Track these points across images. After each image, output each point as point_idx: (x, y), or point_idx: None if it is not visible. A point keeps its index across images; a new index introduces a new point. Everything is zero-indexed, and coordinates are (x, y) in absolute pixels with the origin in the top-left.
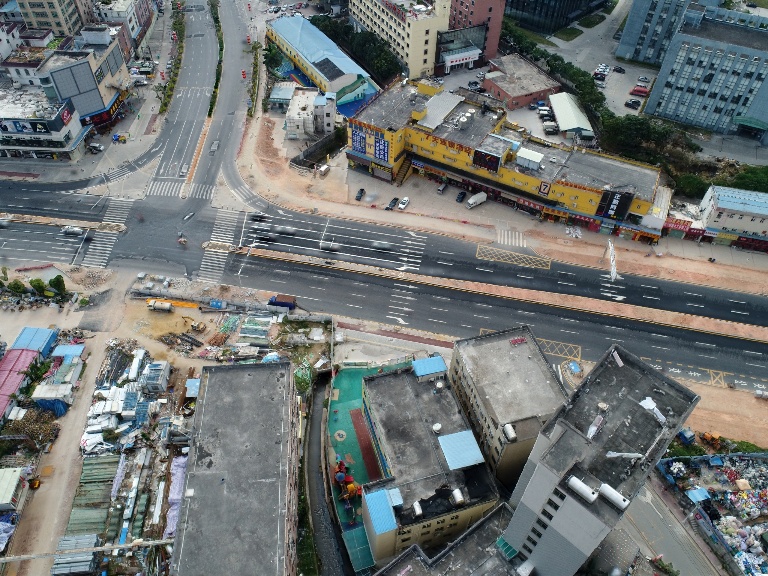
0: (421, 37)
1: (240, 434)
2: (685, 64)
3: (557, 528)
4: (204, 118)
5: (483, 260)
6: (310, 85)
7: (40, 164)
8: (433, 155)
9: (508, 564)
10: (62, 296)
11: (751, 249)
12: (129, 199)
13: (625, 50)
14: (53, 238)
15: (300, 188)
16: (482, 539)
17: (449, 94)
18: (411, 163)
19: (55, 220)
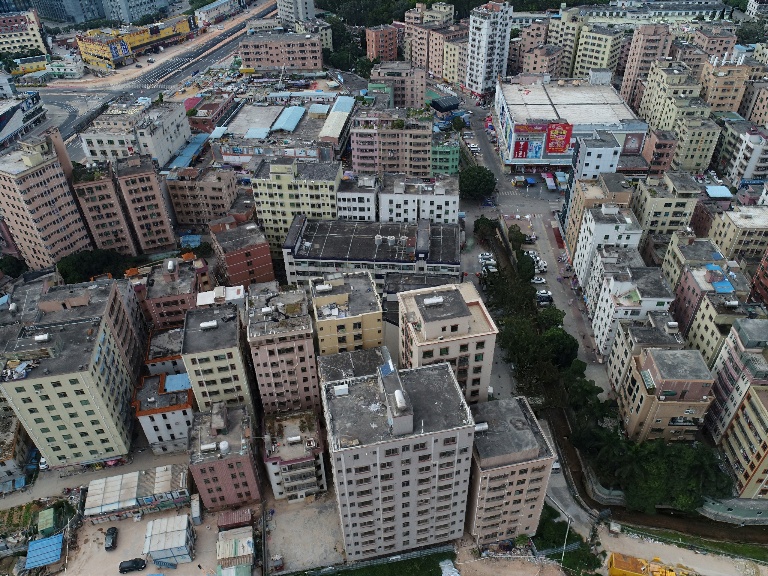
0: None
1: None
2: None
3: None
4: None
5: None
6: None
7: (41, 126)
8: (135, 44)
9: None
10: None
11: (218, 22)
12: None
13: (80, 19)
14: None
15: None
16: None
17: None
18: None
19: None
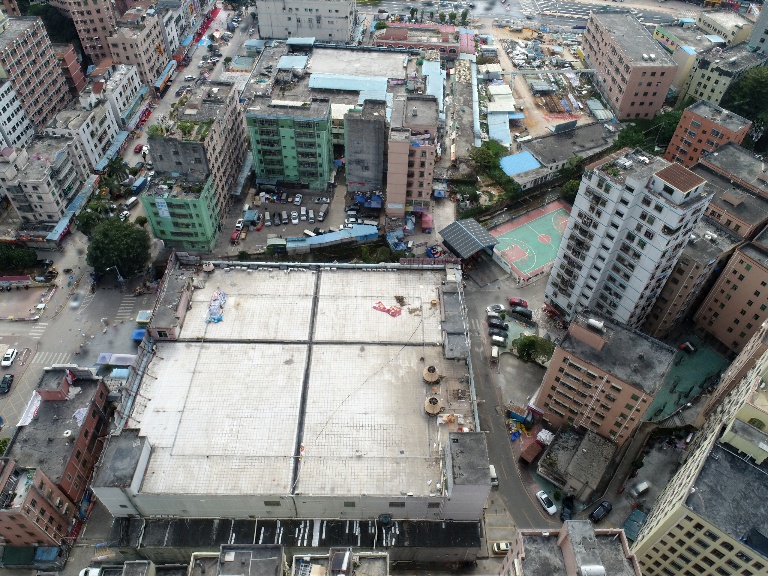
0: None
1: (621, 27)
2: None
3: None
4: None
5: (678, 19)
6: None
7: None
8: None
9: None
10: (463, 23)
11: None
12: None
13: None
14: (436, 7)
15: None
16: (739, 48)
17: None
18: None
19: (432, 0)
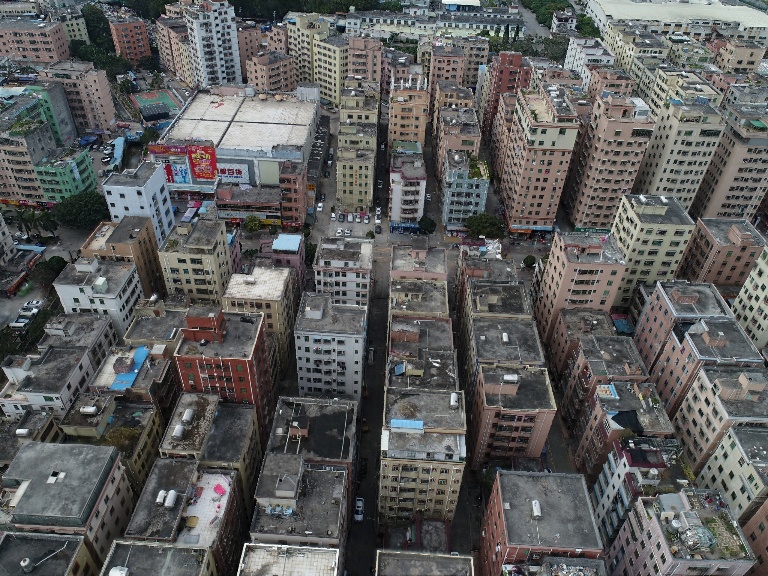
0: None
1: None
2: None
3: None
4: None
5: None
6: None
7: None
8: None
9: (64, 7)
10: None
11: None
12: None
13: None
14: None
15: None
16: (56, 8)
17: None
18: None
19: None
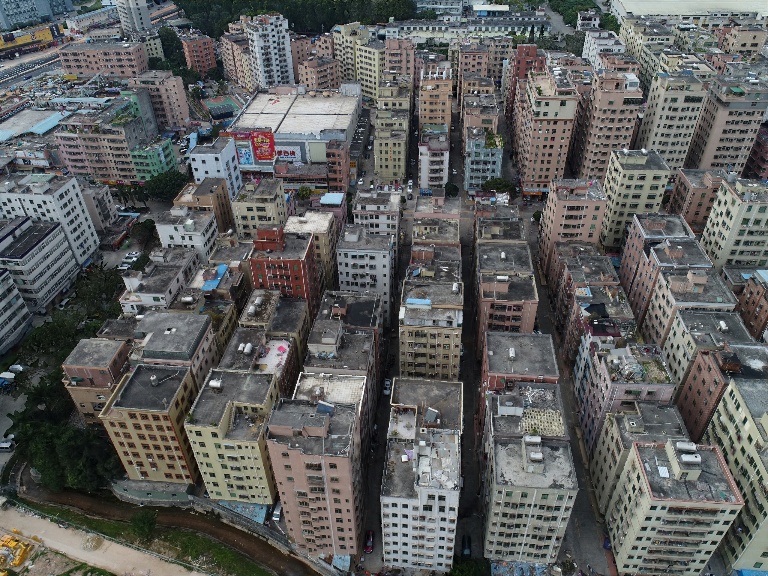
0: None
1: None
2: (6, 4)
3: (140, 5)
4: None
5: (48, 57)
6: None
7: None
8: None
9: None
10: None
11: None
12: None
13: None
14: None
15: None
16: None
17: None
18: None
19: None
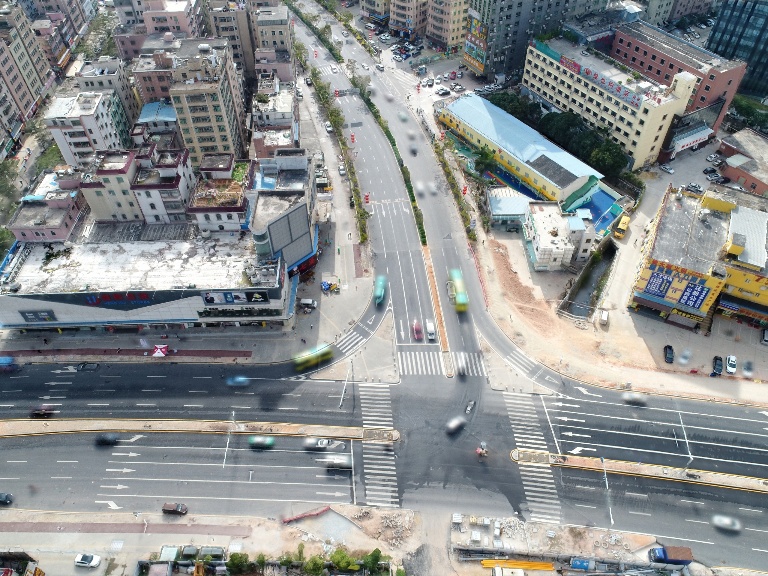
0: (657, 123)
1: None
2: None
3: None
4: (418, 246)
5: None
6: (518, 186)
7: (246, 335)
8: (756, 297)
9: None
10: (371, 569)
11: None
12: (381, 384)
13: None
14: (311, 459)
15: (588, 349)
16: None
17: (748, 210)
18: (718, 304)
19: (303, 428)
